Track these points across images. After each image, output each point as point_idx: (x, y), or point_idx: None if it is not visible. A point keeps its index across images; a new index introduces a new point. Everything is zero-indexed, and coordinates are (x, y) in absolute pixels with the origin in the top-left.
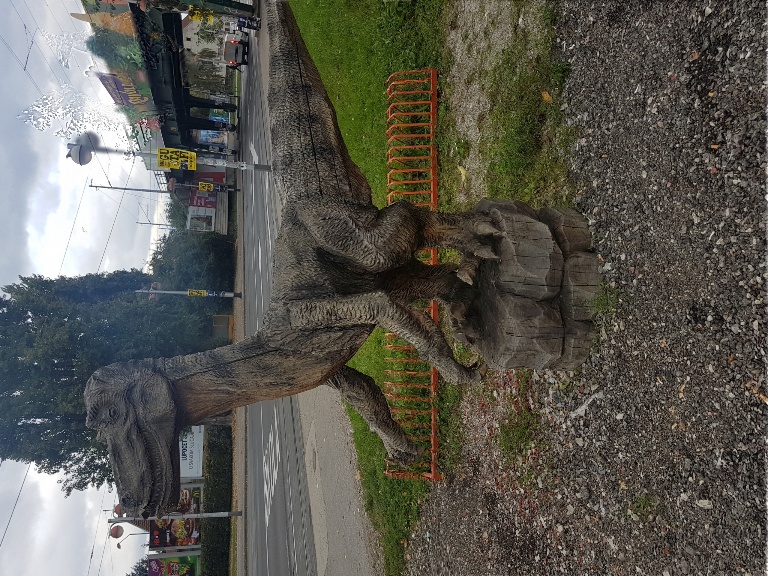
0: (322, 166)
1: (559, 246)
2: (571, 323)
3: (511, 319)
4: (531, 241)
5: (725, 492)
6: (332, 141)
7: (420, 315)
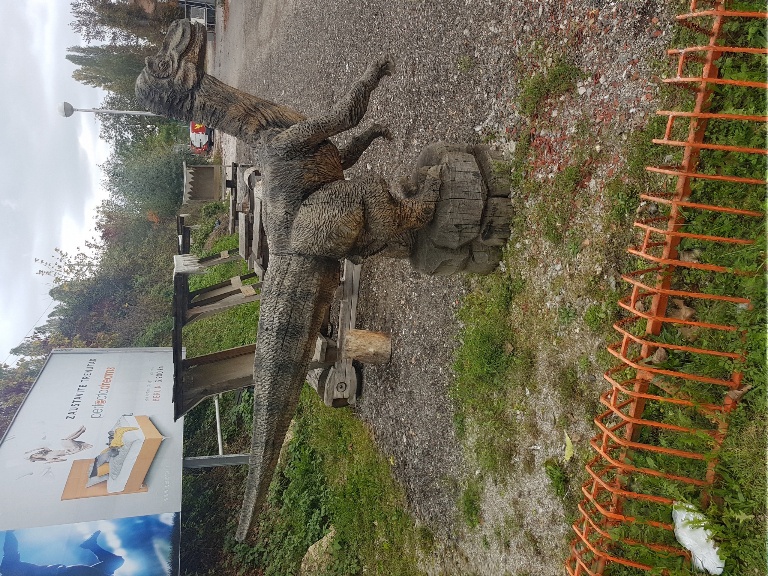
0: None
1: None
2: None
3: None
4: None
5: None
6: None
7: None
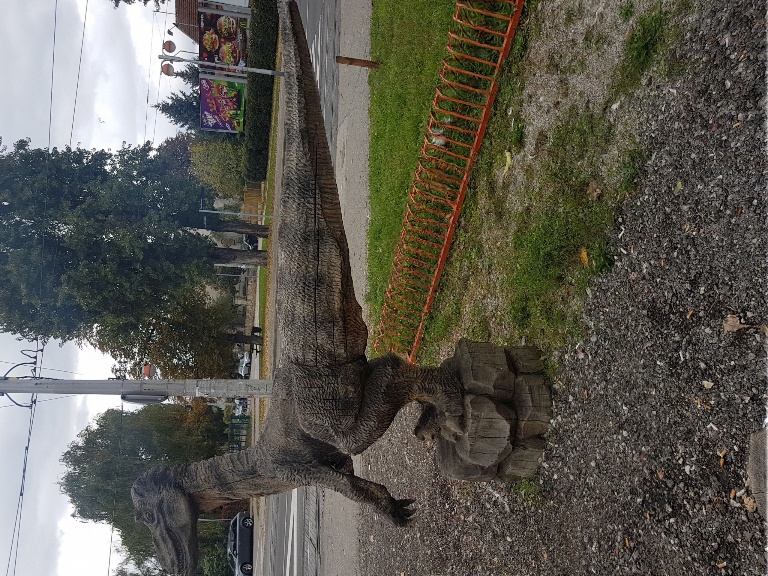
0: (321, 335)
1: (515, 435)
2: (504, 472)
3: (453, 474)
4: (488, 441)
5: None
6: (336, 304)
7: (375, 490)
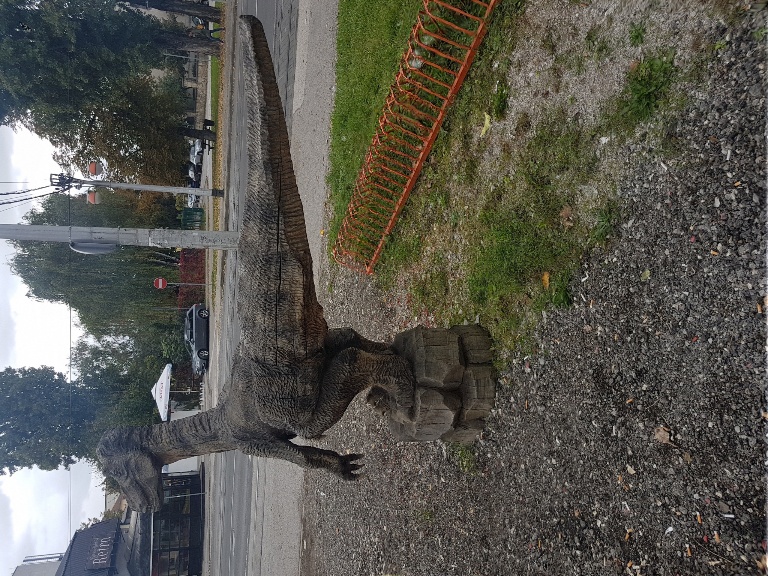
0: (281, 341)
1: None
2: None
3: None
4: (433, 426)
5: (448, 570)
6: (297, 316)
7: None
